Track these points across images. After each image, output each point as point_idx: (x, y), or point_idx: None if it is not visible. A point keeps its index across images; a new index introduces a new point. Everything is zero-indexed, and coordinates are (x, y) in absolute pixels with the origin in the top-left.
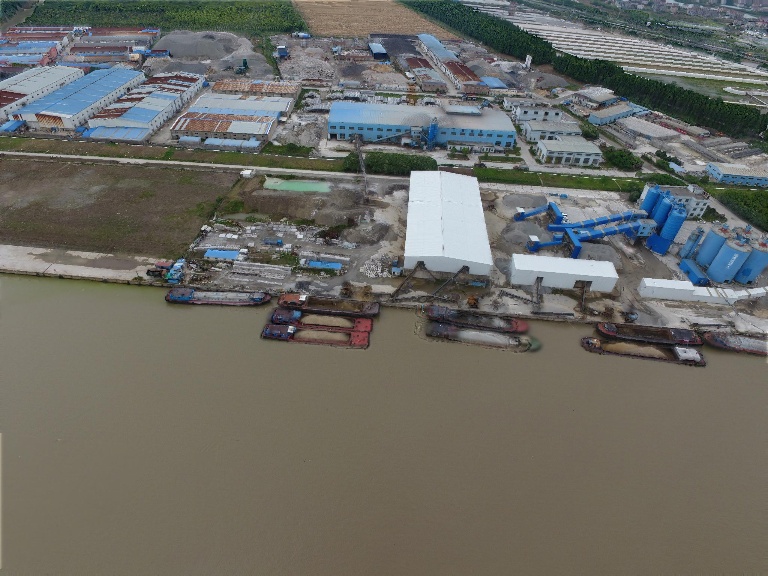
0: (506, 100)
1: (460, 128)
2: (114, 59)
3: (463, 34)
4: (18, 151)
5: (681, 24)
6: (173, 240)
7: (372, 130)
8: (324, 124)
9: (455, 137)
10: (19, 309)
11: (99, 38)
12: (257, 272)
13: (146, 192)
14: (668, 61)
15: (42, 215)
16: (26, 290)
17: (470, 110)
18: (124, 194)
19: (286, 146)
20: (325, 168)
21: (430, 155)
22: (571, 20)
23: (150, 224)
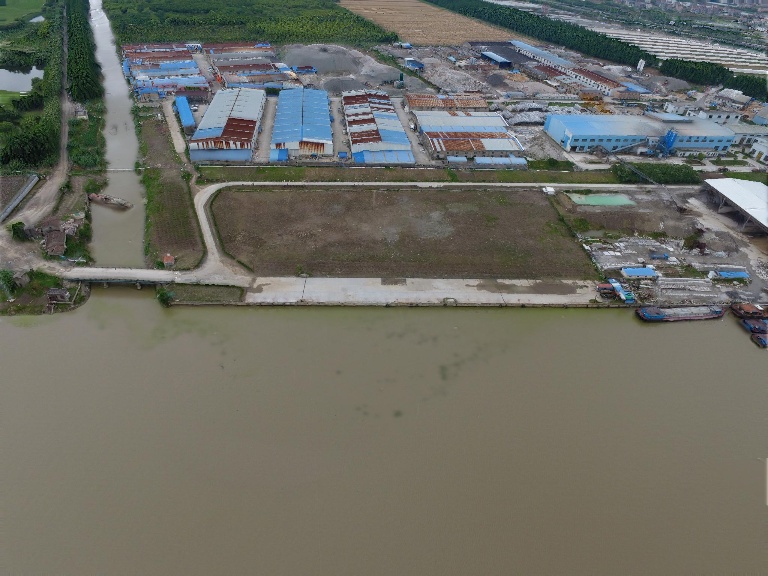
0: (672, 105)
1: (688, 135)
2: (275, 78)
3: (537, 39)
4: (312, 181)
5: (695, 22)
6: (572, 261)
7: (610, 141)
8: (544, 137)
9: (681, 144)
10: (532, 341)
11: (227, 55)
12: (682, 286)
13: (486, 215)
14: (734, 60)
15: (427, 246)
16: (513, 322)
17: (679, 117)
18: (470, 219)
19: (541, 161)
20: (603, 181)
21: (670, 162)
22: (606, 21)
23: (533, 247)
